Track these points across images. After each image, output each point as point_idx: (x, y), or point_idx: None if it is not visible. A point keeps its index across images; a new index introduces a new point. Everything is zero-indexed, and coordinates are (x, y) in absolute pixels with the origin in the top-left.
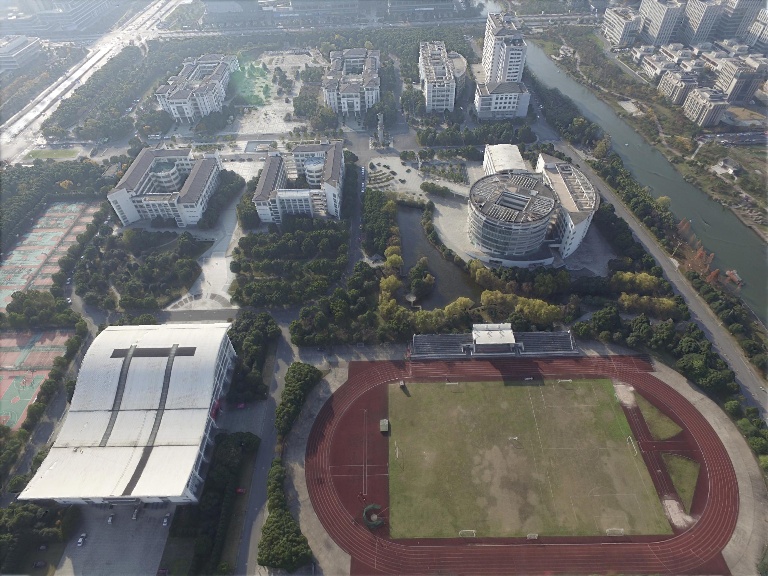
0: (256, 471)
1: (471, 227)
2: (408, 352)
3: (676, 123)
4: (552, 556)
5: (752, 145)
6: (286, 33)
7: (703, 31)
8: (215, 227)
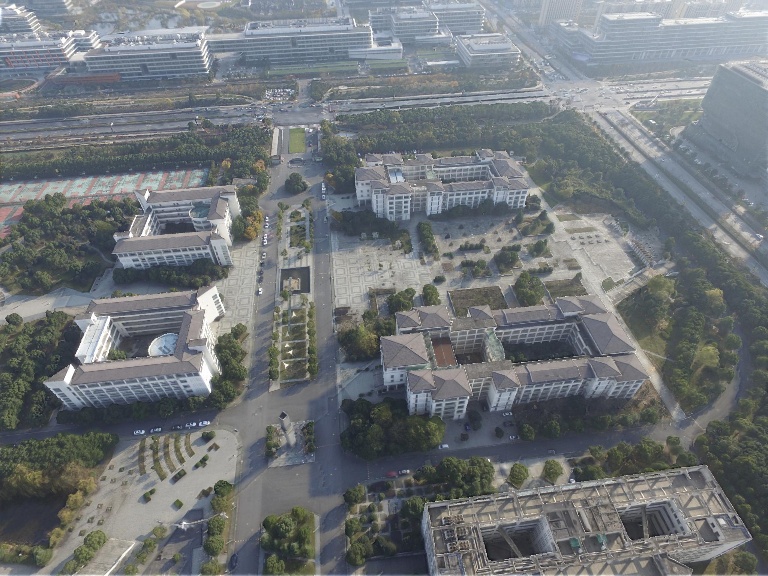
0: None
1: None
2: None
3: None
4: None
5: None
6: (683, 219)
7: None
8: (117, 286)
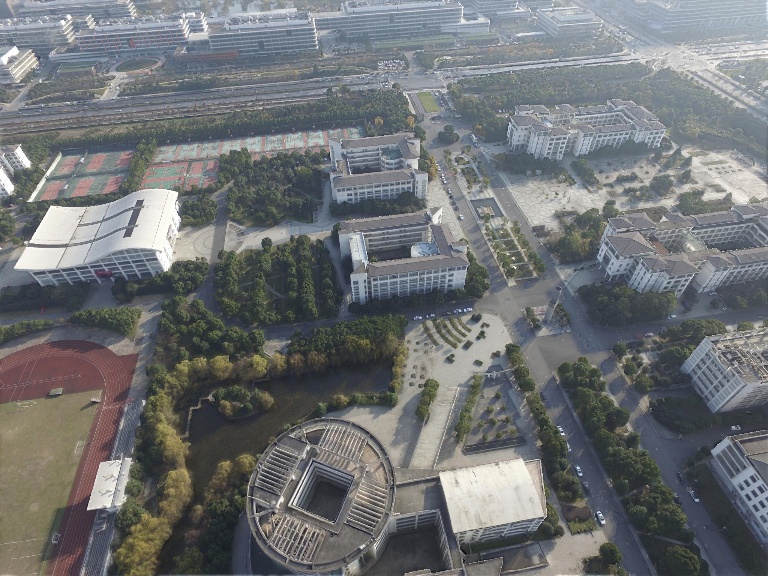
0: (56, 315)
1: None
2: (129, 399)
3: None
4: None
5: None
6: None
7: None
8: (334, 217)
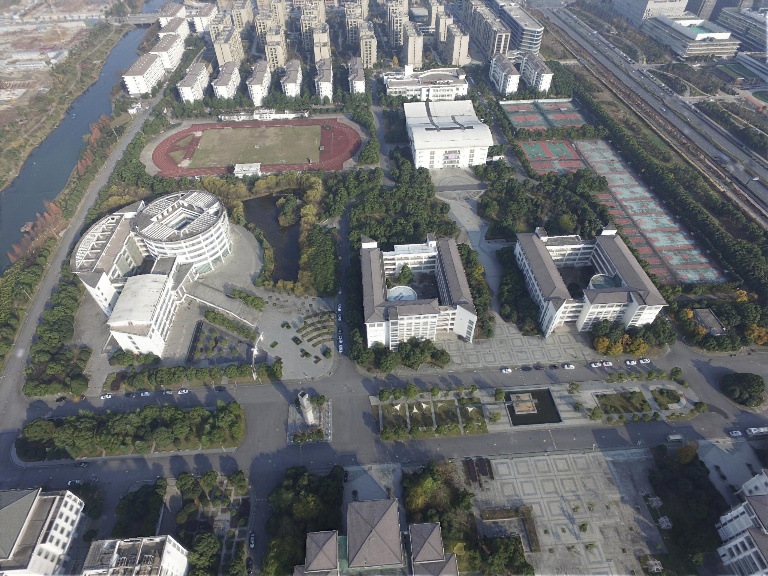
0: None
1: None
2: None
3: None
4: (258, 124)
5: None
6: None
7: None
8: None
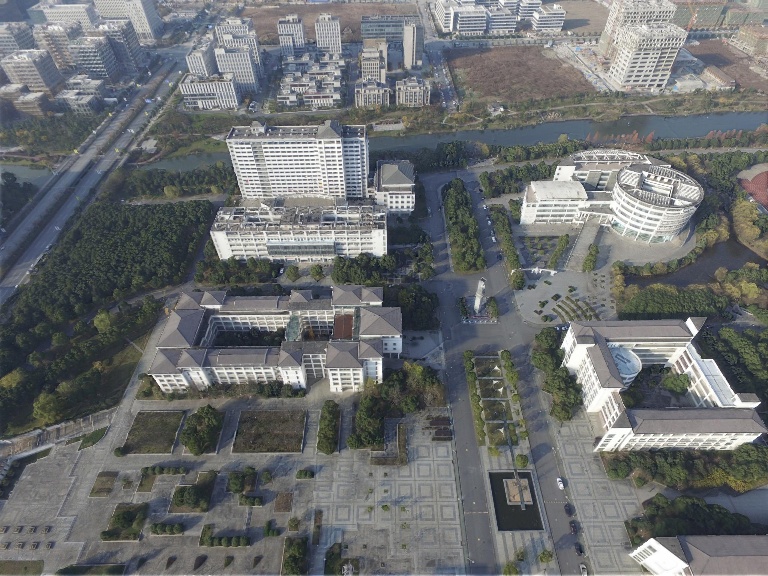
0: None
1: (676, 228)
2: None
3: (427, 112)
4: None
5: (459, 95)
6: None
7: (260, 61)
8: None
